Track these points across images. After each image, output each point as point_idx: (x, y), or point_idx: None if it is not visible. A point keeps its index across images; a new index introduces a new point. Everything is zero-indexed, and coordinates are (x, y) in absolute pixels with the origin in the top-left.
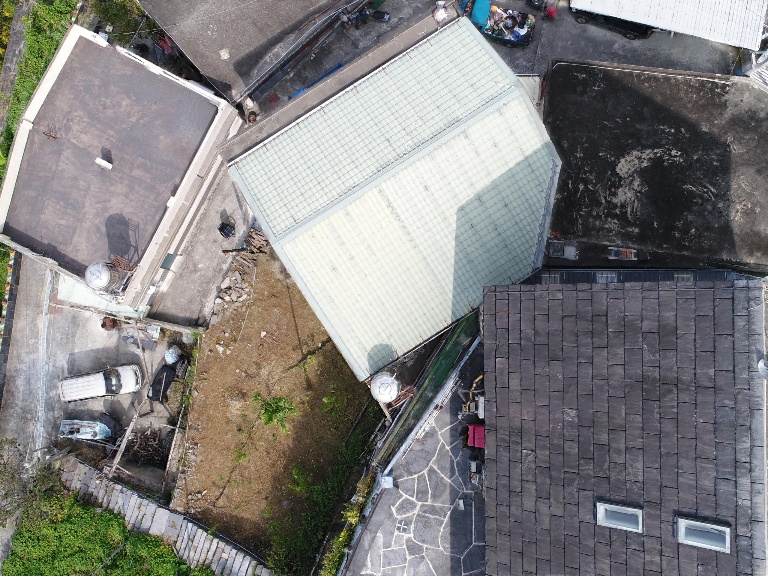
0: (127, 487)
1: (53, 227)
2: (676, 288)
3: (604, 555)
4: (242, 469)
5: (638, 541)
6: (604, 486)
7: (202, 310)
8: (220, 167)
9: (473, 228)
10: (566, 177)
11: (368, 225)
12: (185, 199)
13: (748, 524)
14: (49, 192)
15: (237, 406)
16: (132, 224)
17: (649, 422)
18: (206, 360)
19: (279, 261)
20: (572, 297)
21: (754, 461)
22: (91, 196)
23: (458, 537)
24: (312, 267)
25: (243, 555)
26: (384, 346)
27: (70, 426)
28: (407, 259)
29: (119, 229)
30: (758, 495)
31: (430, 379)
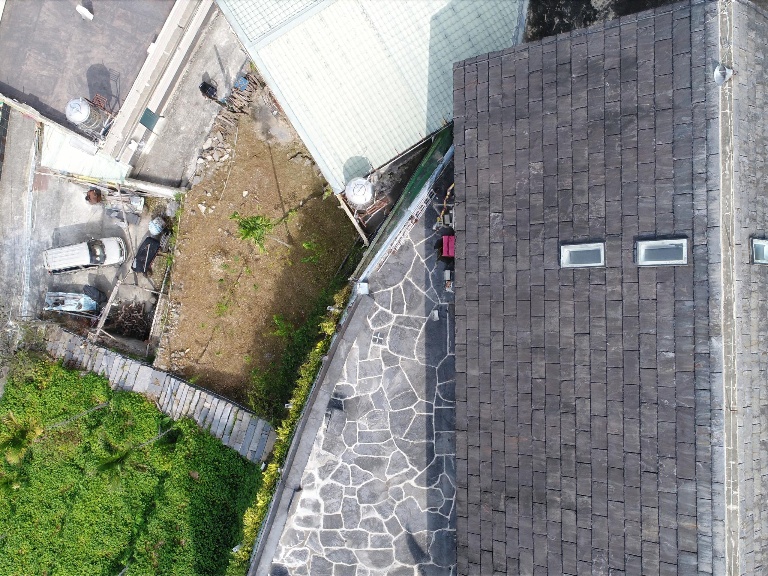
0: (111, 350)
1: (35, 78)
2: (636, 19)
3: (568, 297)
4: (224, 326)
5: (600, 275)
6: (568, 230)
7: (185, 173)
8: (202, 28)
9: (447, 38)
10: (542, 11)
11: (342, 32)
12: (166, 49)
13: (704, 232)
14: (30, 43)
15: (219, 263)
16: (113, 74)
17: (611, 156)
18: (188, 220)
19: (261, 122)
20: (538, 52)
21: (710, 169)
22: (72, 47)
23: (433, 348)
24: (287, 74)
25: (225, 403)
26: (359, 159)
27: (55, 298)
28: (381, 68)
29: (100, 79)
30: (714, 201)
31: (405, 195)
